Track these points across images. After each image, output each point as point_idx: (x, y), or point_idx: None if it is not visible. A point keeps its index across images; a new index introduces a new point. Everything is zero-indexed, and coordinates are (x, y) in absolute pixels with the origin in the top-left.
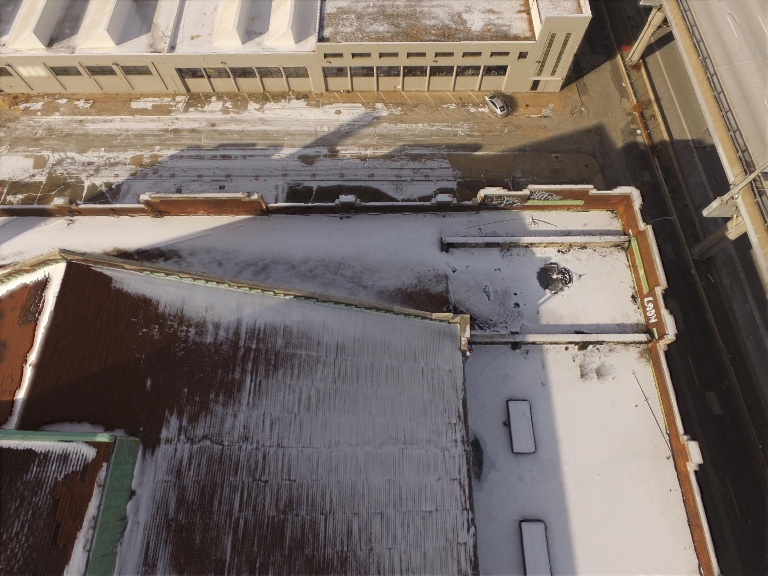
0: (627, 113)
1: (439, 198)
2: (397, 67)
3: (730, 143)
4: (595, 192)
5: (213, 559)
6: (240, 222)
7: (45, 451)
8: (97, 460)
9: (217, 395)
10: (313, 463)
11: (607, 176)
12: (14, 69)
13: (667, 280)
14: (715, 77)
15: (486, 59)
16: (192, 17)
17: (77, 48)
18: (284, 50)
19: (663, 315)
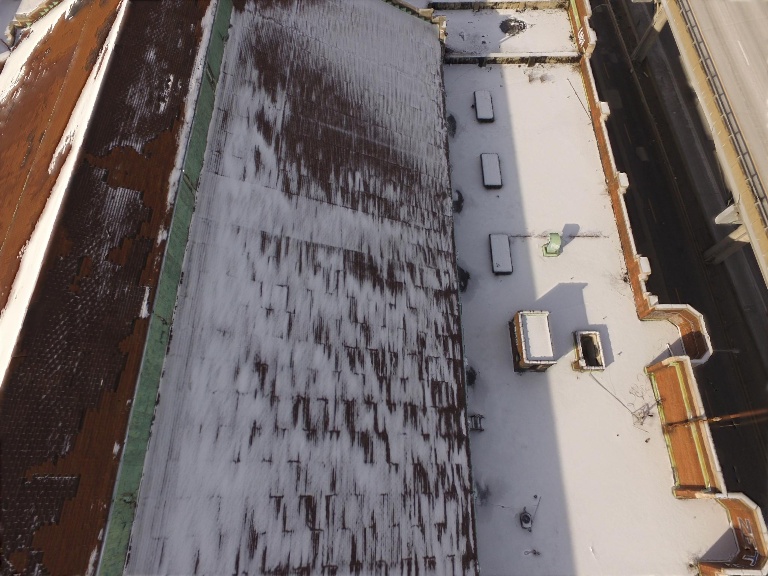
0: None
1: None
2: None
3: None
4: None
5: (279, 73)
6: None
7: None
8: None
9: (277, 2)
10: (338, 56)
11: None
12: None
13: (611, 77)
14: None
15: None
16: None
17: None
18: None
19: (588, 32)
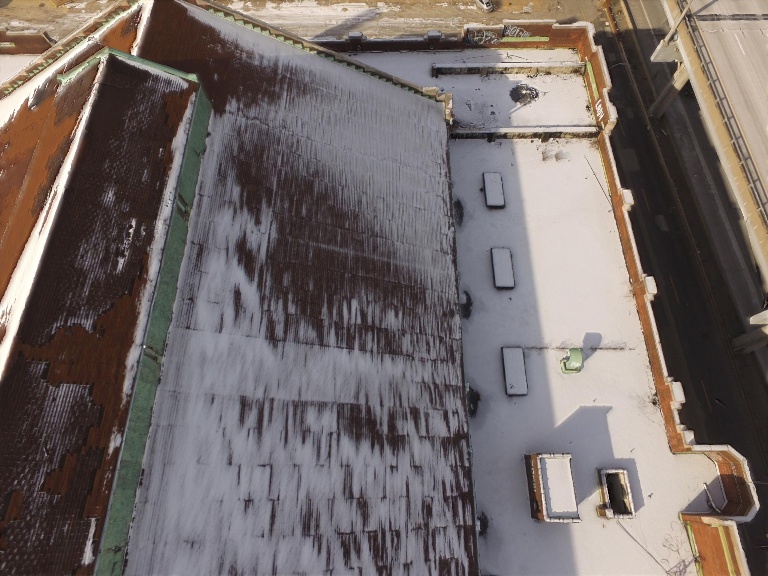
0: (597, 9)
1: (430, 33)
2: None
3: None
4: (557, 25)
5: (264, 186)
6: None
7: (156, 74)
8: (189, 89)
9: (263, 97)
10: (333, 155)
11: None
12: None
13: (627, 134)
14: None
15: None
16: None
17: None
18: None
19: (608, 107)
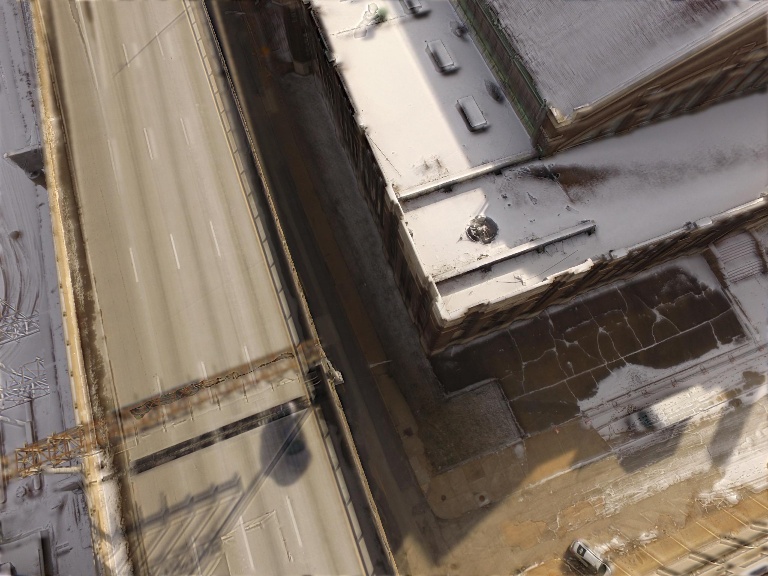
0: None
1: (624, 251)
2: (761, 545)
3: None
4: (485, 301)
5: None
6: None
7: None
8: None
9: None
10: None
11: (416, 491)
12: None
13: None
14: (370, 572)
15: None
16: None
17: None
18: None
19: None
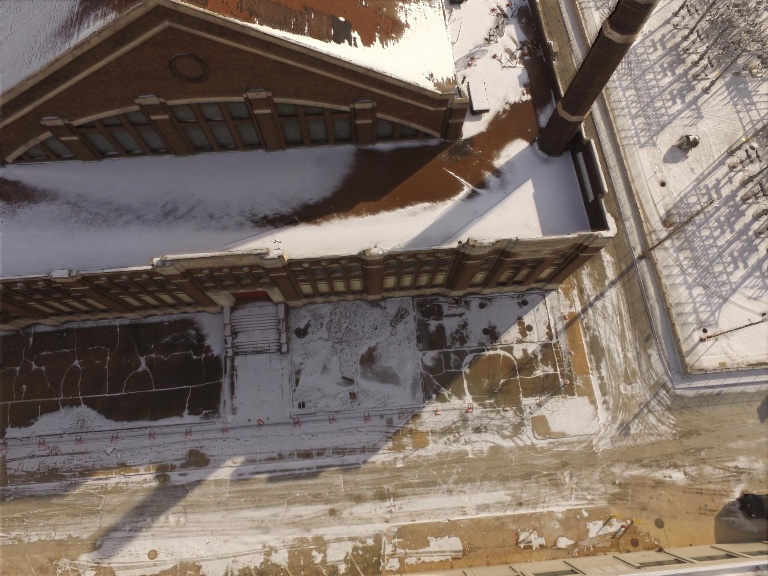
0: None
1: None
2: None
3: None
4: None
5: None
6: None
7: None
8: None
9: None
10: None
11: None
12: (634, 567)
13: None
14: None
15: None
16: None
17: None
18: None
19: None
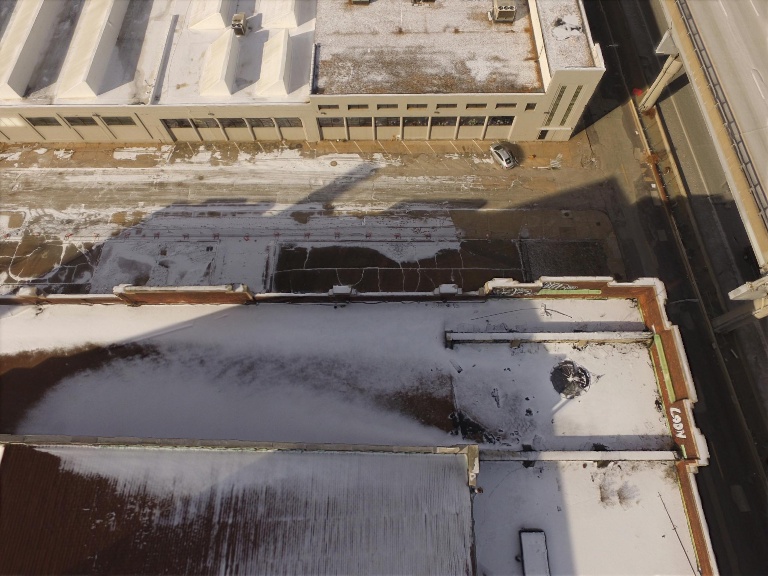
0: (641, 164)
1: (443, 289)
2: (396, 118)
3: (761, 225)
4: (614, 284)
5: None
6: (225, 312)
7: None
8: None
9: None
10: None
11: (620, 236)
12: None
13: None
14: (741, 144)
15: (491, 110)
16: (178, 63)
17: (55, 98)
18: (276, 101)
19: (693, 434)
